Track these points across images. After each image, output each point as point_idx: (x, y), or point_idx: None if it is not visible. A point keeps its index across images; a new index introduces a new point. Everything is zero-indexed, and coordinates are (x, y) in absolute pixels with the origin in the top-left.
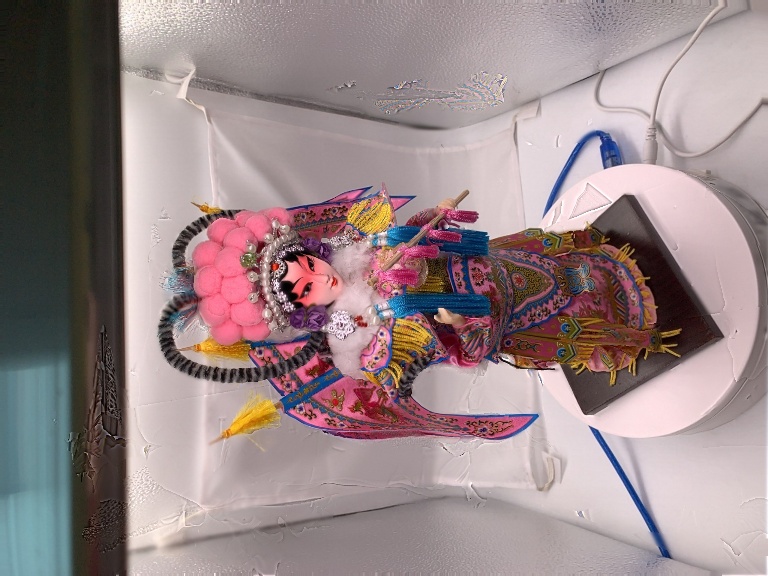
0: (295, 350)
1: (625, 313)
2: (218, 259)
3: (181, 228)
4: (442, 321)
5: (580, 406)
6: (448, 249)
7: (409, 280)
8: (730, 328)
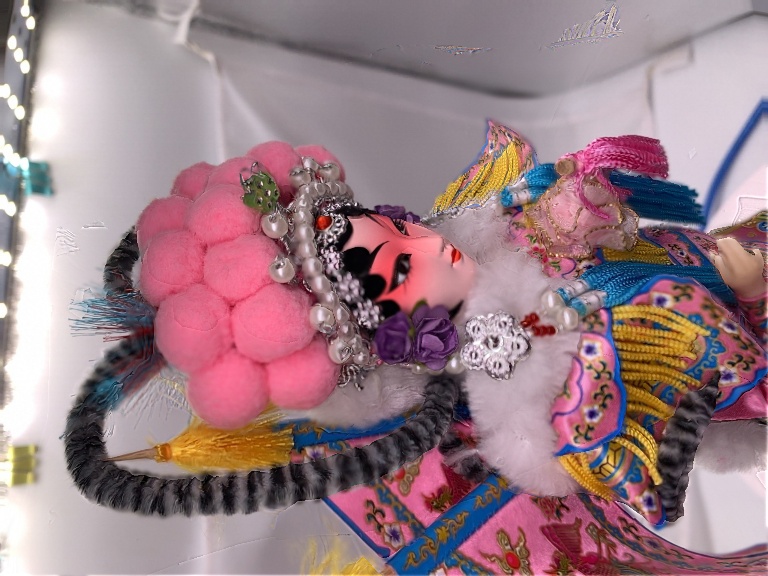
0: None
1: None
2: (191, 208)
3: (124, 234)
4: (732, 274)
5: None
6: (638, 209)
7: (650, 153)
8: None
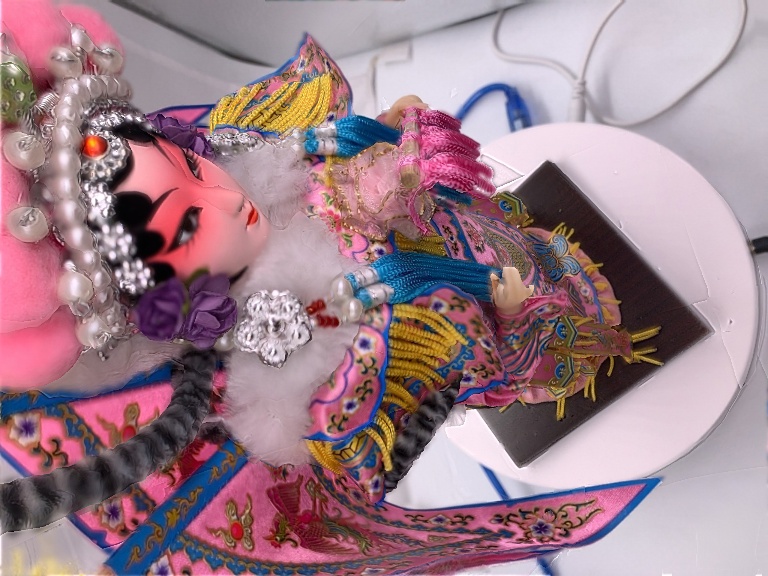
0: (125, 413)
1: (583, 313)
2: None
3: None
4: (505, 299)
5: (511, 457)
6: None
7: None
8: (720, 319)
